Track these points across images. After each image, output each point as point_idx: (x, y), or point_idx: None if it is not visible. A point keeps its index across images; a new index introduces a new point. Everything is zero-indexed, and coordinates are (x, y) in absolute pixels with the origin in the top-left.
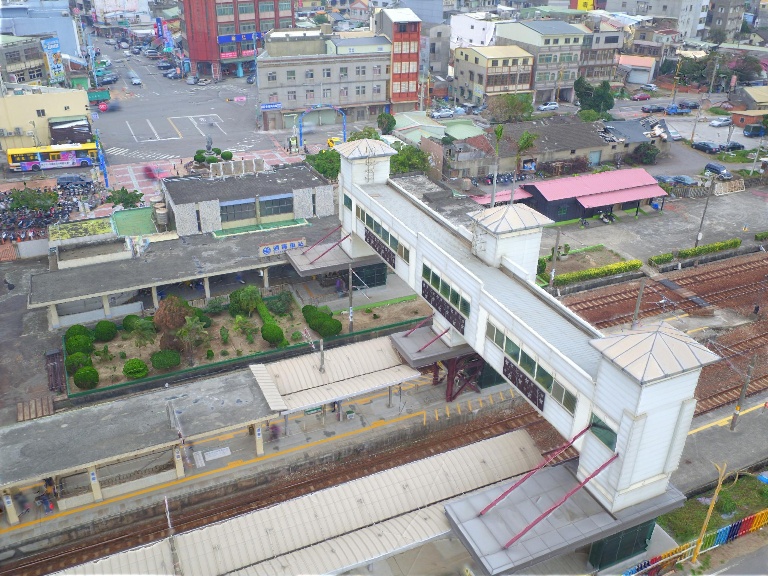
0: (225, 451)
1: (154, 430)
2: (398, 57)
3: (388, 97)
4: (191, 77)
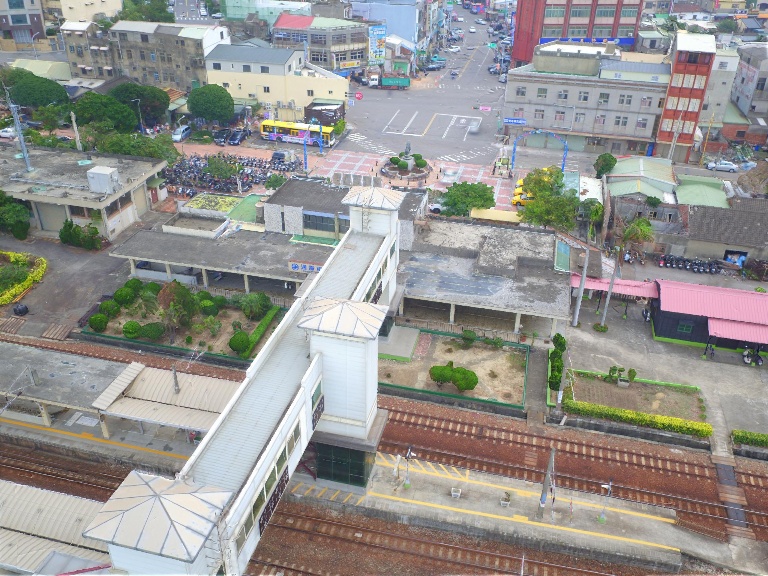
0: (94, 422)
1: (24, 381)
2: (676, 91)
3: (655, 134)
4: (503, 75)
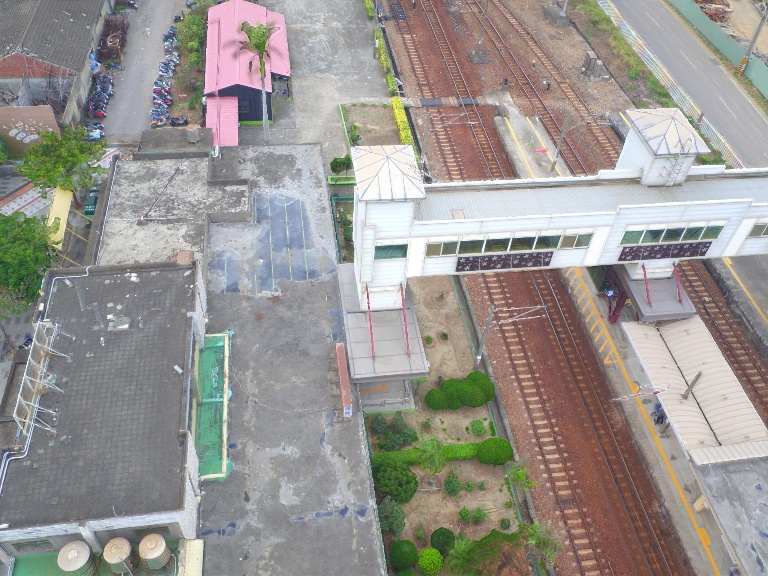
0: None
1: None
2: None
3: None
4: None
